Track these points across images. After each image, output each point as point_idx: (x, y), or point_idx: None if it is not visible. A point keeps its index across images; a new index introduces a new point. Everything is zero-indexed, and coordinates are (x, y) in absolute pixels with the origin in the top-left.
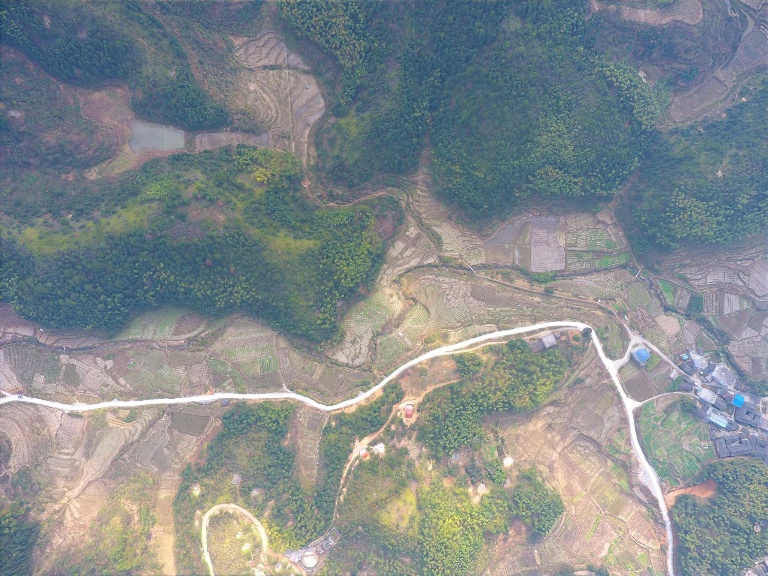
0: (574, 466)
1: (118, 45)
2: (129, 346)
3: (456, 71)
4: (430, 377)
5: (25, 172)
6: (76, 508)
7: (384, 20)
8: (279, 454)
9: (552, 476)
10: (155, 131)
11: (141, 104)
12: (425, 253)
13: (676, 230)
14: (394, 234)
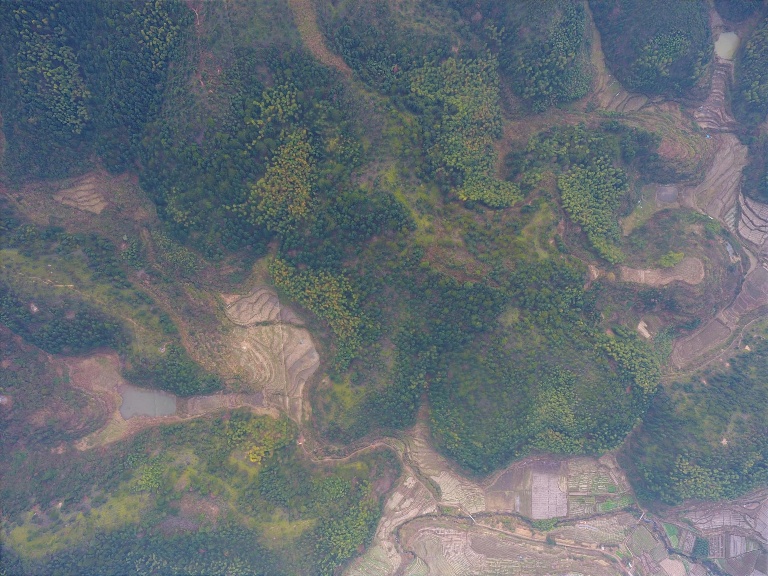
0: None
1: (107, 327)
2: None
3: (453, 348)
4: None
5: (13, 450)
6: None
7: (378, 303)
8: None
9: None
10: (146, 396)
11: (131, 376)
12: (424, 503)
13: (680, 492)
14: (392, 487)
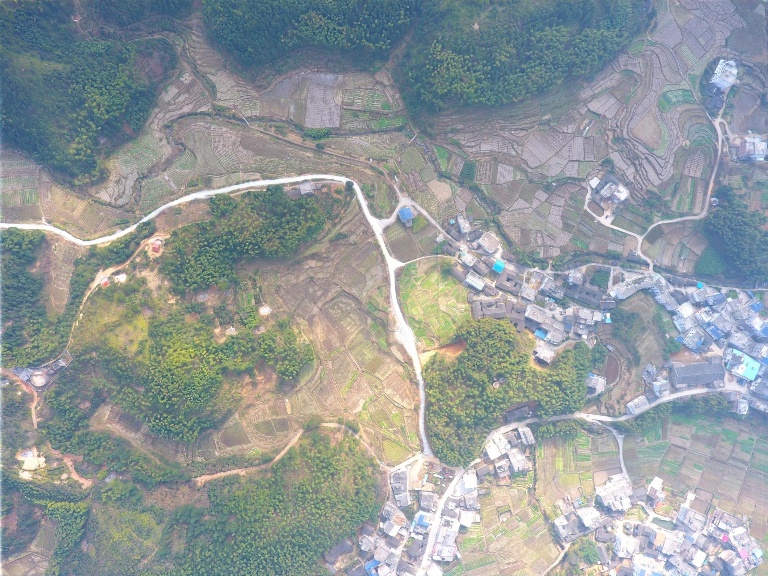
0: (334, 322)
1: None
2: None
3: None
4: (184, 216)
5: None
6: None
7: None
8: (20, 277)
9: (311, 330)
10: None
11: None
12: (199, 100)
13: (436, 84)
14: (166, 77)
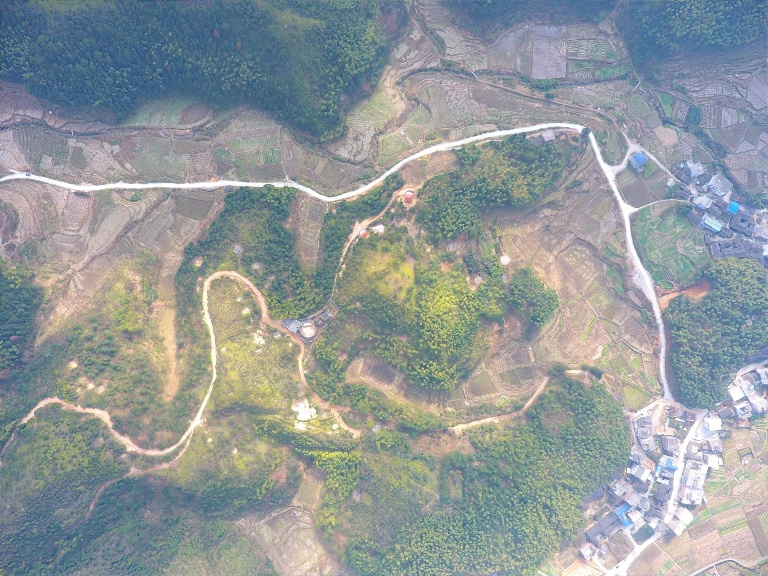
0: (570, 269)
1: None
2: (136, 133)
3: None
4: (430, 167)
5: None
6: (80, 280)
7: None
8: (280, 232)
9: (548, 278)
10: None
11: None
12: (428, 56)
13: (676, 27)
14: (398, 35)
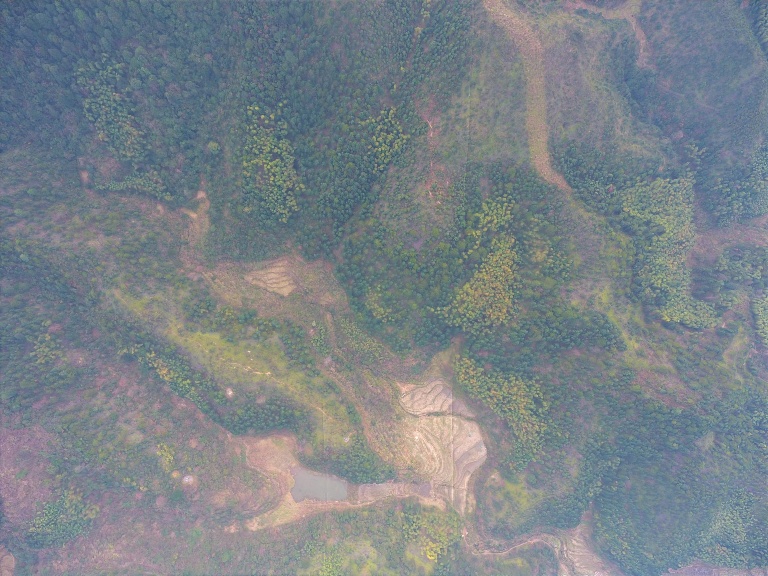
0: None
1: (297, 415)
2: None
3: (636, 461)
4: None
5: (190, 527)
6: None
7: (570, 414)
8: None
9: None
10: (318, 480)
11: (310, 461)
12: None
13: None
14: None
